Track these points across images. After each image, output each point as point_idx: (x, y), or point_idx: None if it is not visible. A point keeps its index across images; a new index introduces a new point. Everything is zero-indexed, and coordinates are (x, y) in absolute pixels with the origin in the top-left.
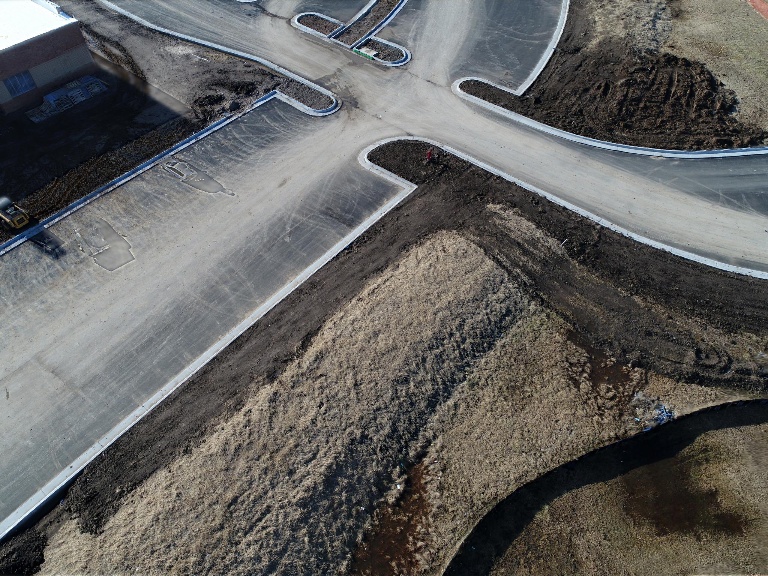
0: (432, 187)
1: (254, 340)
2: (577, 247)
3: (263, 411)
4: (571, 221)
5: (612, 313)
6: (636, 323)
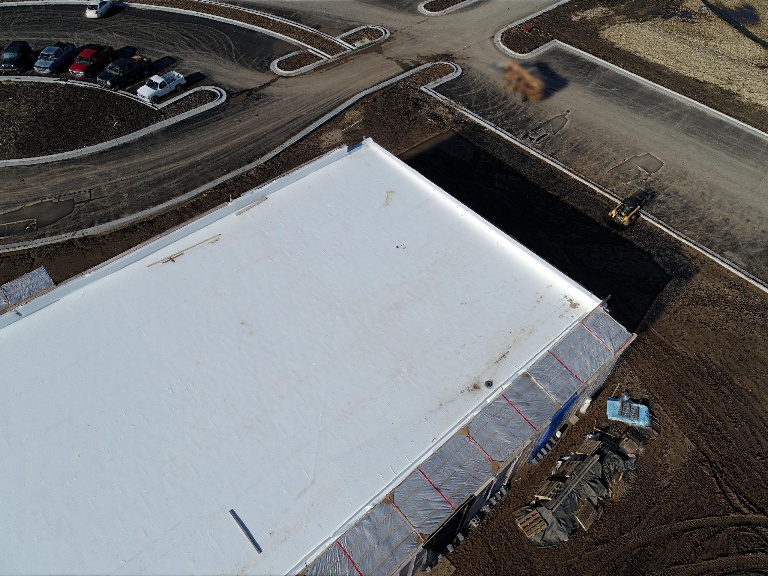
0: (556, 34)
1: (709, 101)
2: (604, 3)
3: (760, 95)
4: (583, 0)
5: (647, 6)
6: (652, 2)
